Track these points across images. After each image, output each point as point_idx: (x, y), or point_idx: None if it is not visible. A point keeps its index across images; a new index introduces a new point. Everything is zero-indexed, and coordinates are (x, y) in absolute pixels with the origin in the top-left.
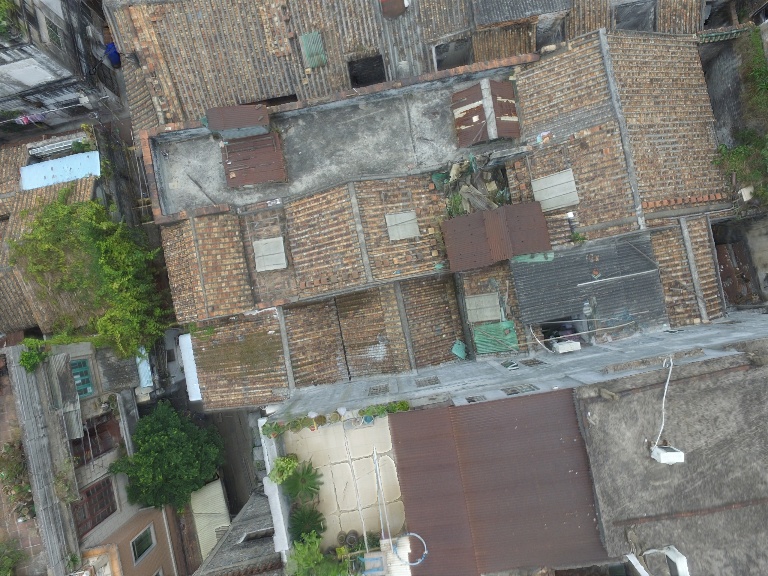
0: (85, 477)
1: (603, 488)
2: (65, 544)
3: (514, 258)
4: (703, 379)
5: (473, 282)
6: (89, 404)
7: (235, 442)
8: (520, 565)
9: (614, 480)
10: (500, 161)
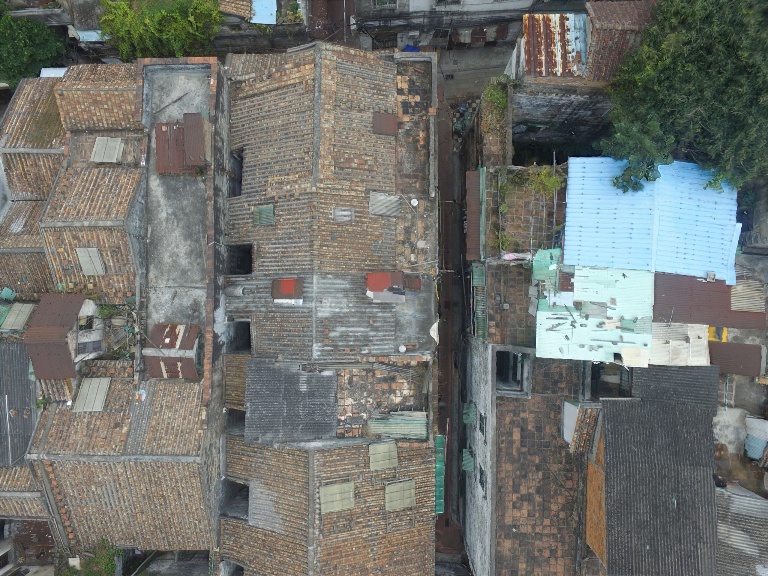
0: None
1: None
2: None
3: None
4: None
5: None
6: None
7: None
8: None
9: None
10: None
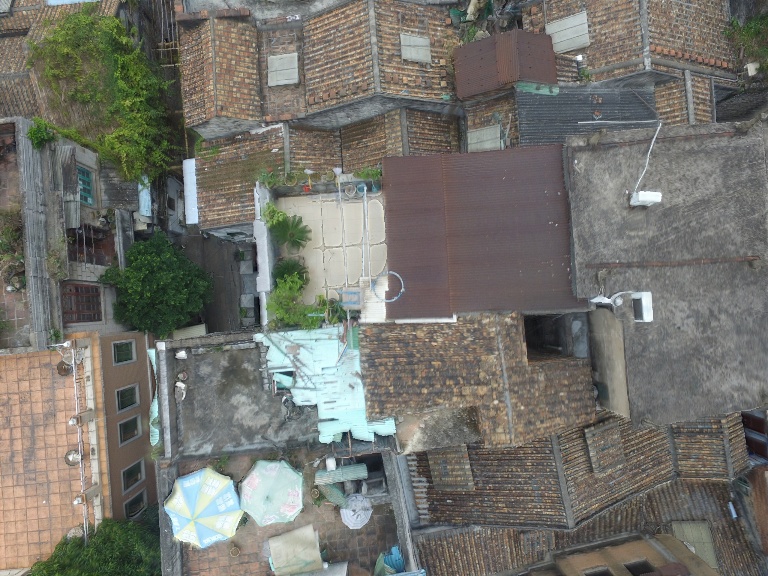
0: (76, 272)
1: (580, 233)
2: (50, 319)
3: (520, 86)
4: (689, 140)
5: (477, 118)
6: (88, 211)
7: (223, 302)
8: (492, 307)
9: (592, 226)
10: (517, 7)
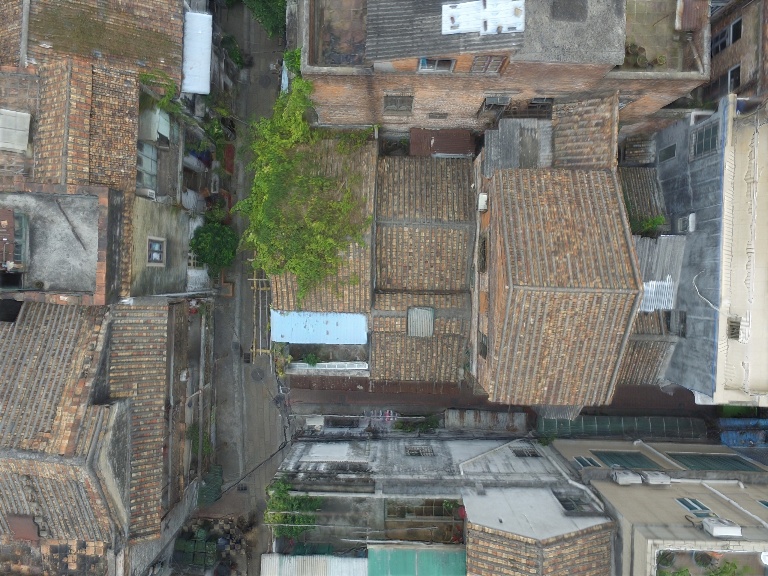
0: None
1: None
2: None
3: None
4: None
5: None
6: None
7: None
8: None
9: None
10: None
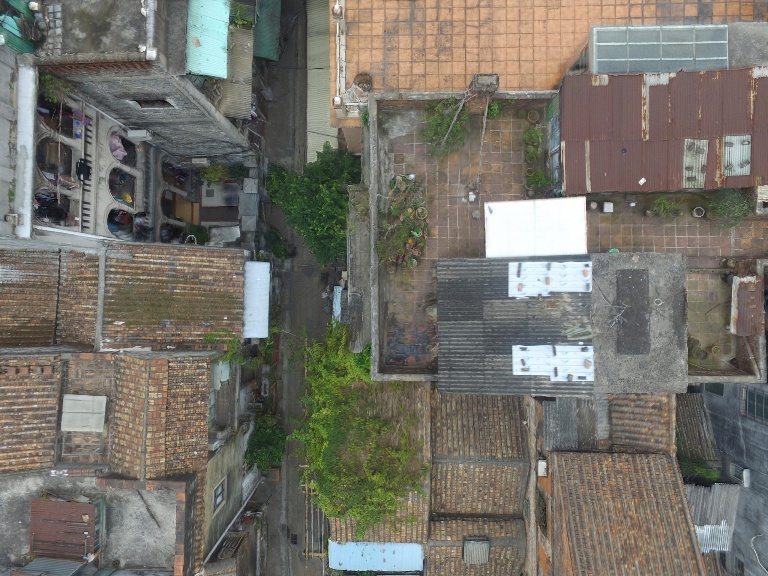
0: None
1: None
2: None
3: None
4: None
5: None
6: None
7: None
8: None
9: None
10: None
